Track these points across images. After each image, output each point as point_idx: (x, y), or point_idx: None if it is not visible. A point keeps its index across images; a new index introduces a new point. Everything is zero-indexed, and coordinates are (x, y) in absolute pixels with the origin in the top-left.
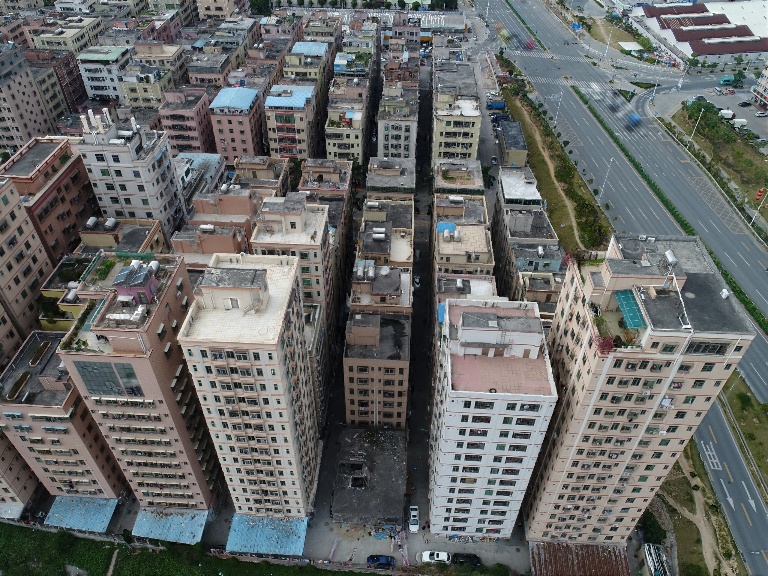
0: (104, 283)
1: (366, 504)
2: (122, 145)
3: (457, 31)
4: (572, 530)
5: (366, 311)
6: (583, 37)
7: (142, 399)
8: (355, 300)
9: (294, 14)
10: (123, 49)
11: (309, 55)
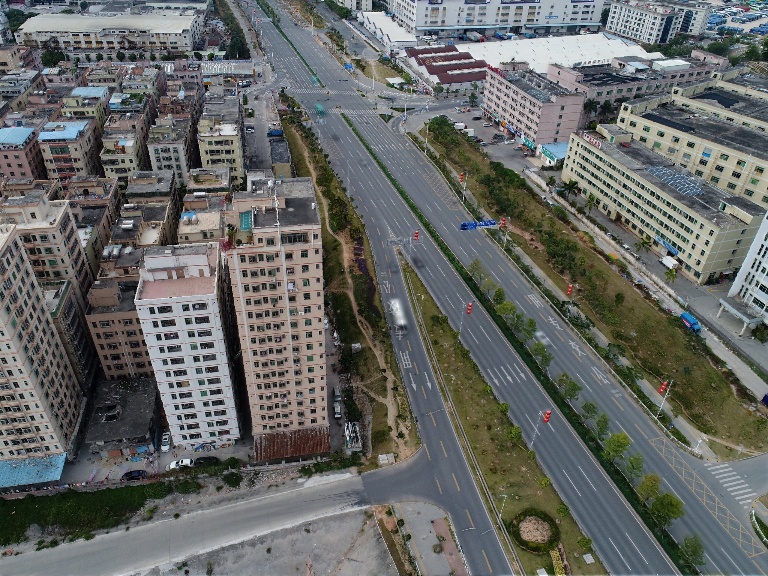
0: None
1: (116, 431)
2: None
3: (247, 76)
4: (282, 418)
5: None
6: (357, 76)
7: None
8: (103, 276)
9: None
10: None
11: (87, 97)
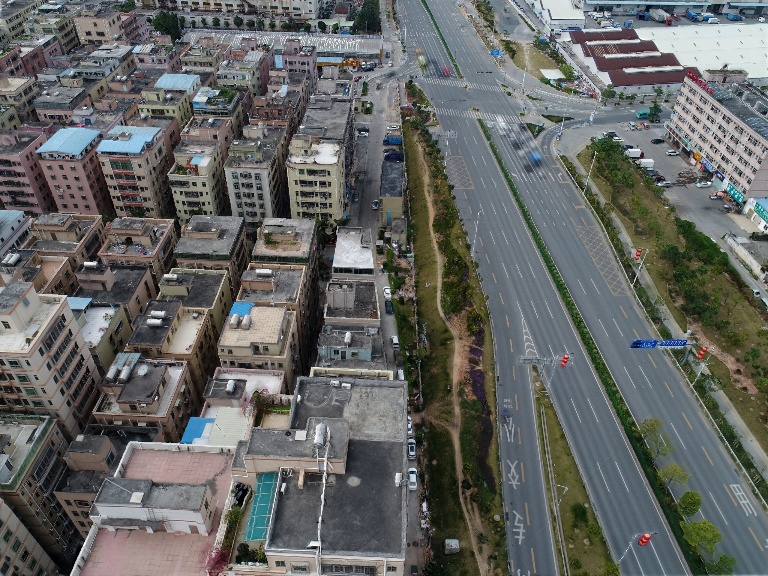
0: None
1: None
2: None
3: (372, 56)
4: None
5: (115, 420)
6: (505, 64)
7: None
8: (104, 406)
9: (174, 42)
10: None
11: (172, 89)
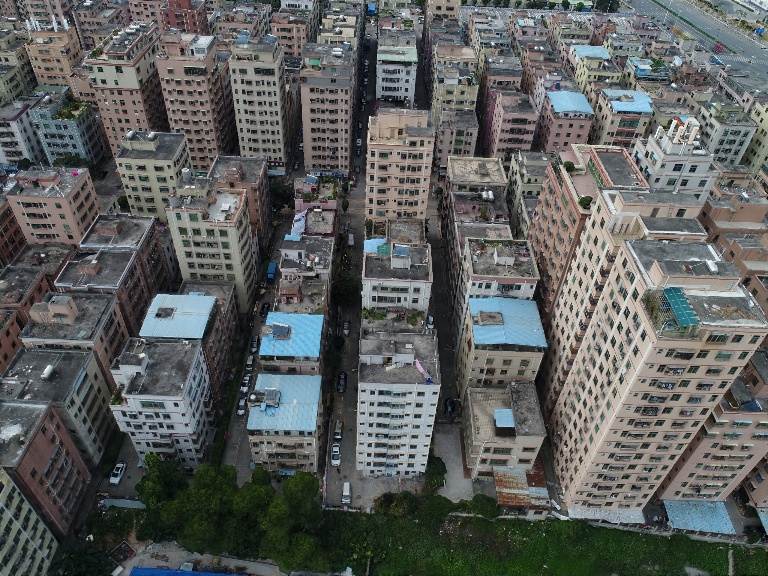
0: None
1: None
2: (708, 156)
3: None
4: None
5: None
6: None
7: None
8: None
9: None
10: (414, 50)
11: None
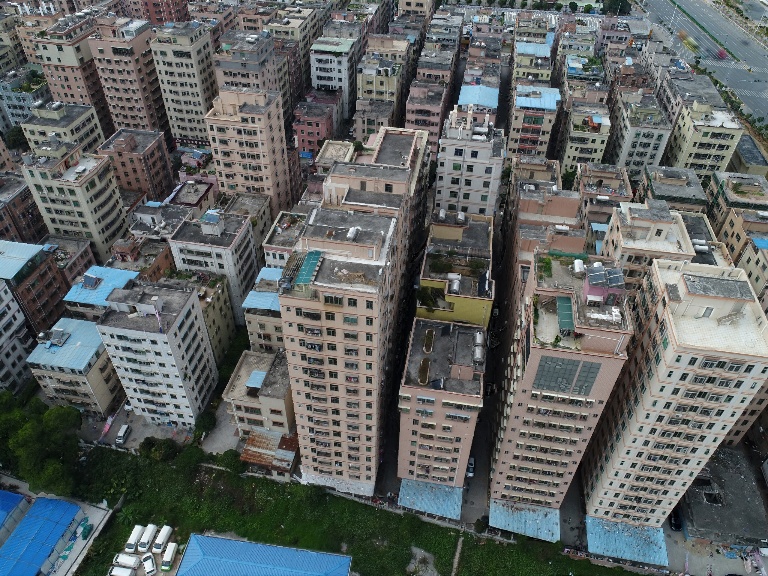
0: (554, 280)
1: (729, 522)
2: None
3: (640, 37)
4: None
5: None
6: None
7: (584, 398)
8: None
9: None
10: (351, 41)
11: (536, 56)
